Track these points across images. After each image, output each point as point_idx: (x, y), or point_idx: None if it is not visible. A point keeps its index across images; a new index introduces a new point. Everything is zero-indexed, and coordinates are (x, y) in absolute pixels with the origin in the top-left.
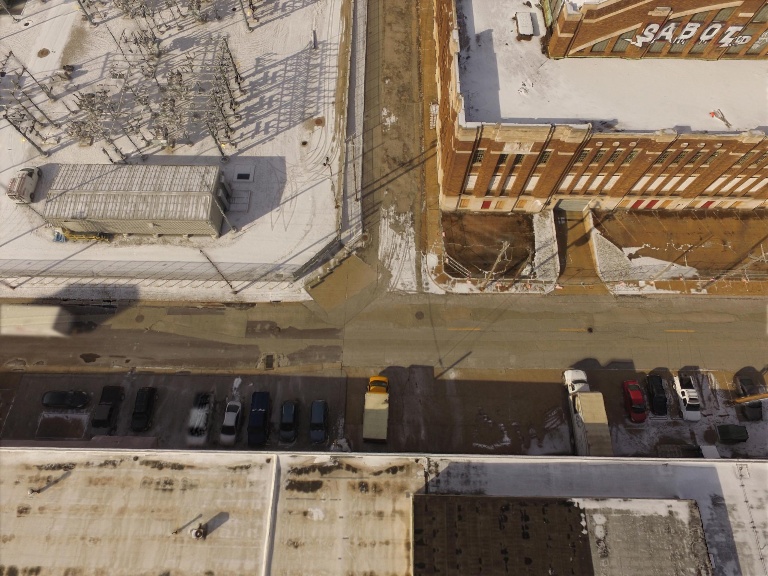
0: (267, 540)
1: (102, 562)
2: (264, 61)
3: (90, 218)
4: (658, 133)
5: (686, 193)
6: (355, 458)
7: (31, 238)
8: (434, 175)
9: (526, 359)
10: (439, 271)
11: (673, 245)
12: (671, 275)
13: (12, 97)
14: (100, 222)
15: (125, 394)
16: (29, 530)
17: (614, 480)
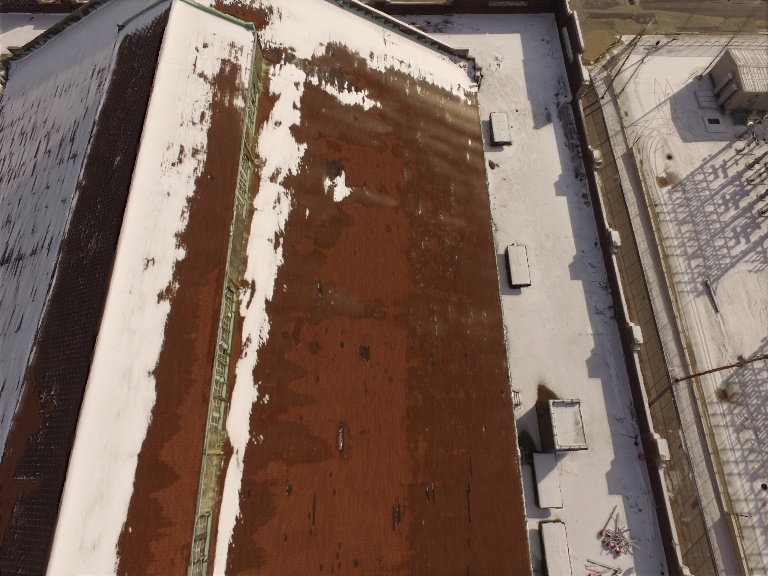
0: None
1: None
2: (759, 259)
3: None
4: None
5: None
6: None
7: None
8: None
9: None
10: None
11: None
12: None
13: None
14: None
15: None
16: None
17: None
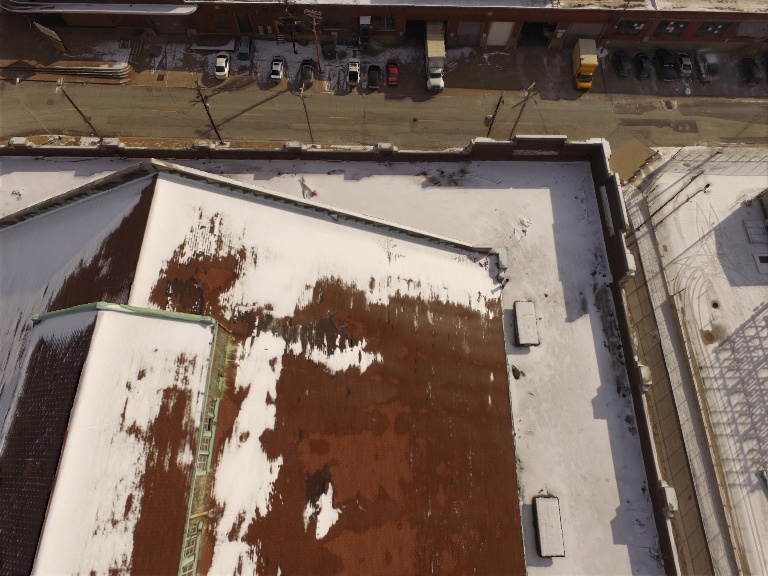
0: None
1: None
2: None
3: None
4: (396, 148)
5: None
6: None
7: None
8: None
9: (469, 103)
10: None
11: None
12: None
13: None
14: None
15: (767, 83)
16: None
17: None
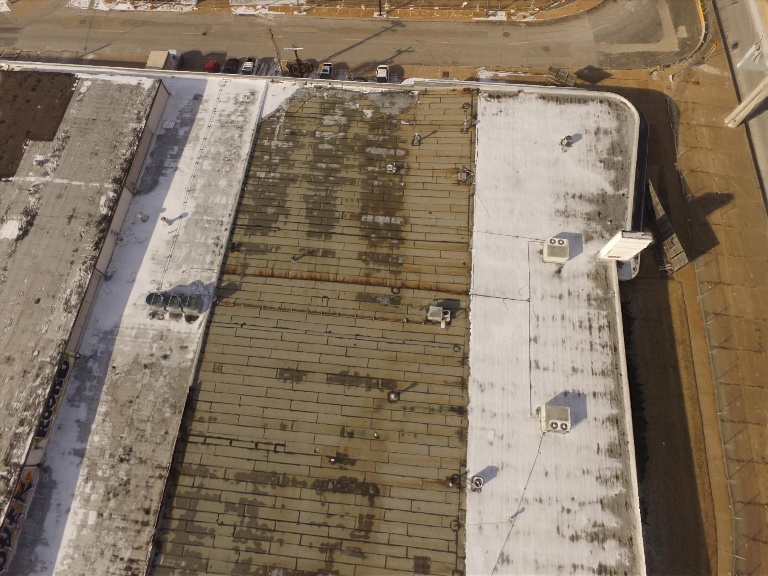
0: None
1: None
2: None
3: None
4: None
5: None
6: None
7: None
8: None
9: (148, 49)
10: None
11: None
12: (284, 2)
13: None
14: None
15: None
16: None
17: None
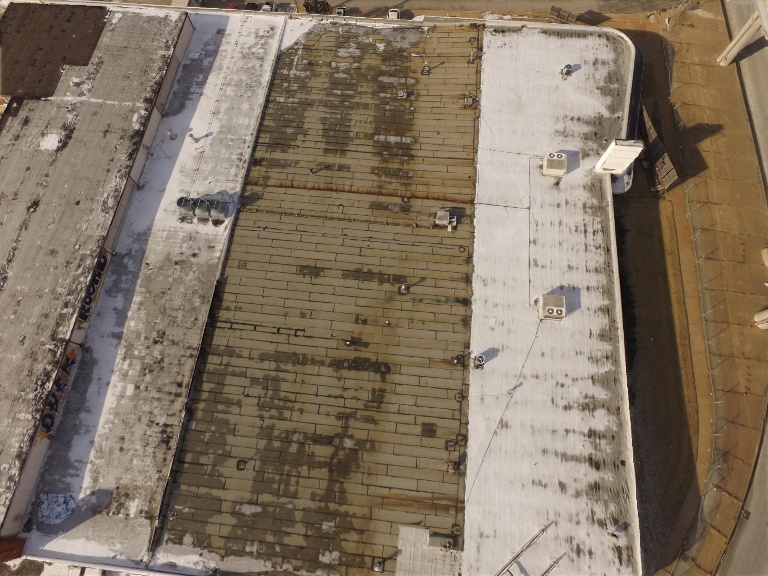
0: None
1: None
2: None
3: None
4: None
5: None
6: None
7: None
8: None
9: None
10: None
11: None
12: None
13: None
14: None
15: None
16: None
17: None
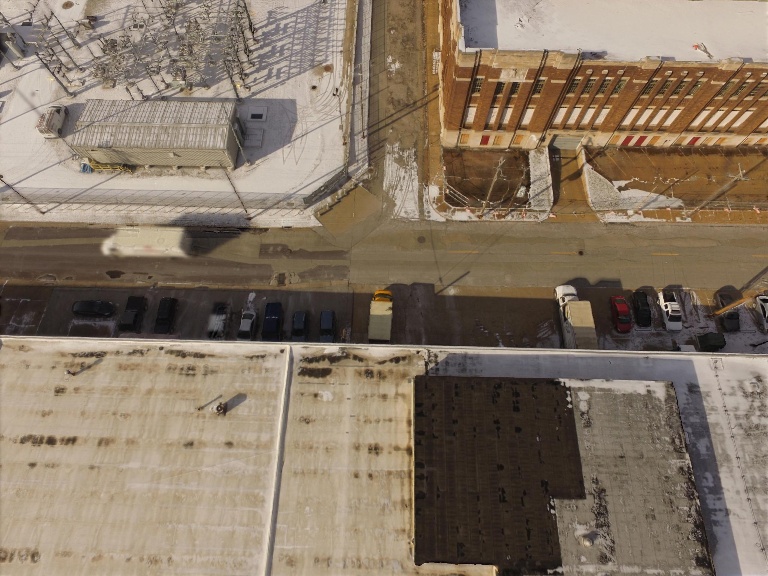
0: (281, 416)
1: (132, 433)
2: (276, 14)
3: (115, 147)
4: (644, 60)
5: (672, 128)
6: (361, 349)
7: (59, 169)
8: (436, 115)
9: (520, 278)
10: (440, 201)
11: (660, 179)
12: (658, 205)
13: (39, 44)
14: (124, 152)
15: (148, 305)
16: (66, 406)
17: (599, 370)
